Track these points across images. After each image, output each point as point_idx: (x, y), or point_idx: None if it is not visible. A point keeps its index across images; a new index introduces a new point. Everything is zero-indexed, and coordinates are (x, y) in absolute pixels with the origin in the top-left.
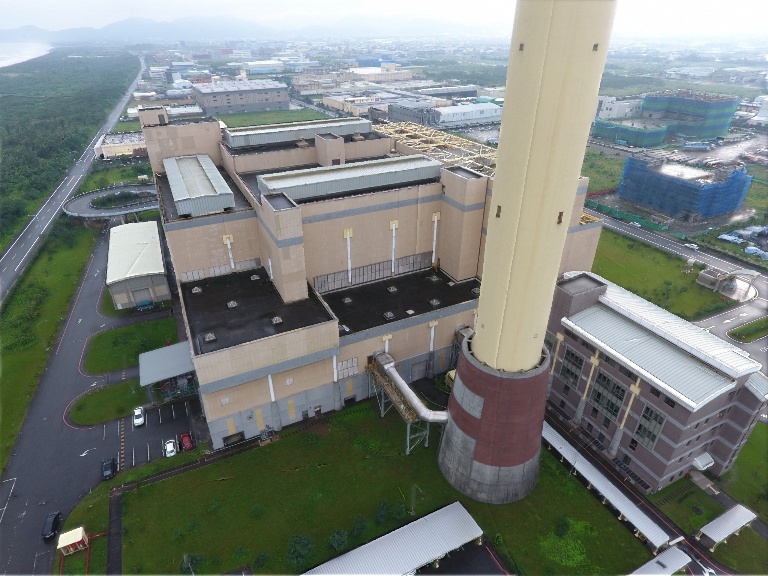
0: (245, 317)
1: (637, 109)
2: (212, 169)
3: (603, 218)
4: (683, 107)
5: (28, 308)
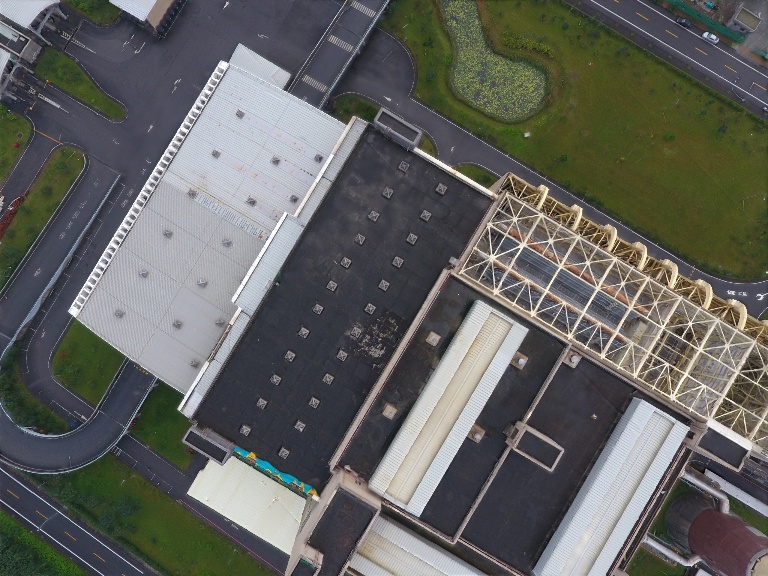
0: None
1: None
2: (442, 562)
3: (669, 32)
4: None
5: None
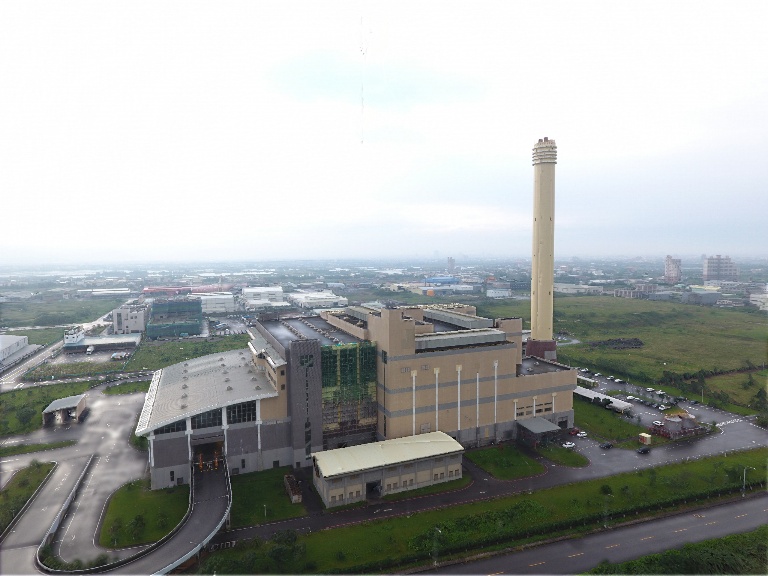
0: (538, 368)
1: (145, 315)
2: None
3: None
4: (180, 307)
5: (481, 516)
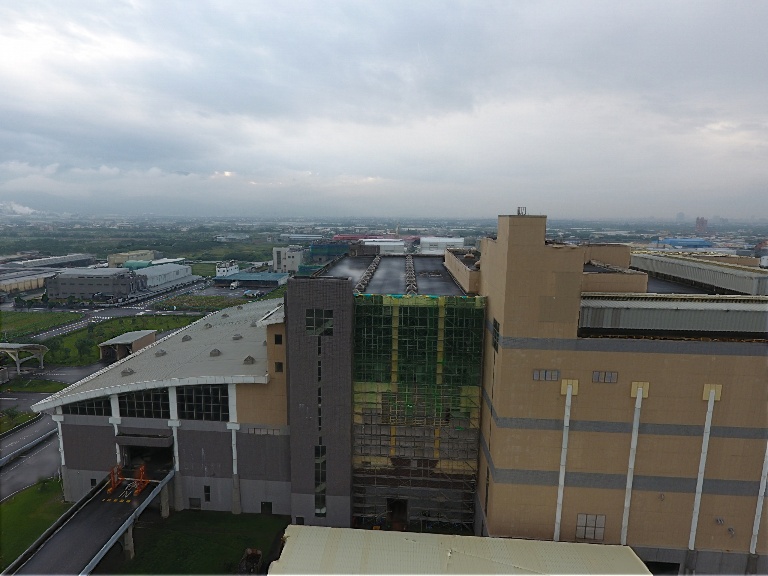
0: None
1: (305, 256)
2: None
3: None
4: (340, 250)
5: None
